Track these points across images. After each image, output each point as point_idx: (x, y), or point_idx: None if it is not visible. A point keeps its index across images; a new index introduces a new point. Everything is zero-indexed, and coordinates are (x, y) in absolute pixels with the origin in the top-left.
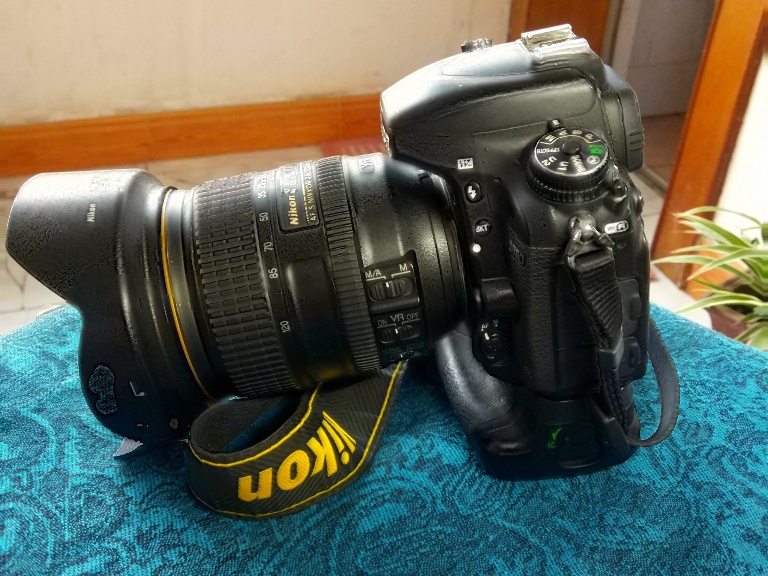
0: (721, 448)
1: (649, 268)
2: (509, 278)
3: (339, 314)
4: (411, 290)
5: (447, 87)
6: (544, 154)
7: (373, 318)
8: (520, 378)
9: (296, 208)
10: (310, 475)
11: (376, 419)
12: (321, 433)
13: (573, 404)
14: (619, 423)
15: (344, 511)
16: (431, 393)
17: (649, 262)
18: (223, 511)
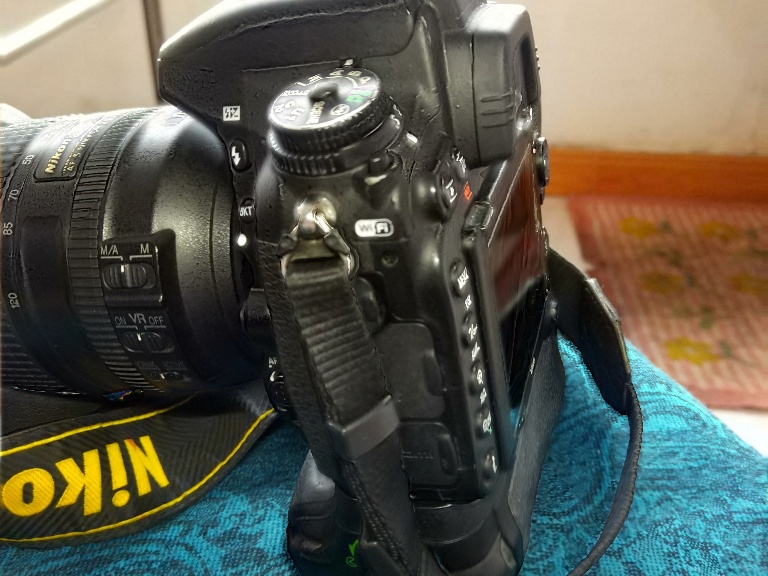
0: None
1: (449, 311)
2: None
3: (72, 297)
4: (154, 283)
5: (232, 5)
6: (286, 97)
7: (110, 312)
8: None
9: (61, 153)
10: (55, 505)
11: (216, 465)
12: (91, 456)
13: None
14: (389, 554)
15: (93, 566)
16: None
17: (447, 300)
18: None
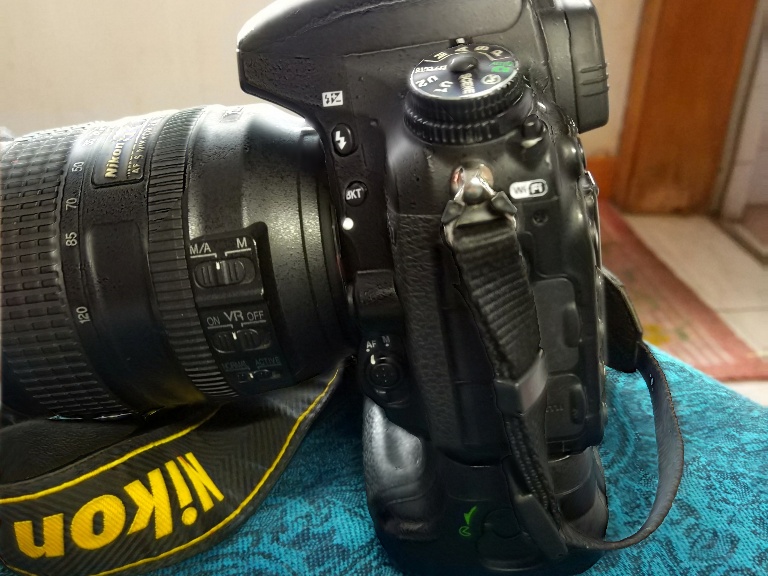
0: (743, 571)
1: (590, 263)
2: (392, 270)
3: (155, 303)
4: (253, 277)
5: None
6: (423, 73)
7: (201, 313)
8: (425, 427)
9: (119, 157)
10: (126, 532)
11: (264, 472)
12: (155, 476)
13: (492, 472)
14: (541, 504)
15: None
16: (354, 449)
17: (589, 253)
18: (14, 568)
